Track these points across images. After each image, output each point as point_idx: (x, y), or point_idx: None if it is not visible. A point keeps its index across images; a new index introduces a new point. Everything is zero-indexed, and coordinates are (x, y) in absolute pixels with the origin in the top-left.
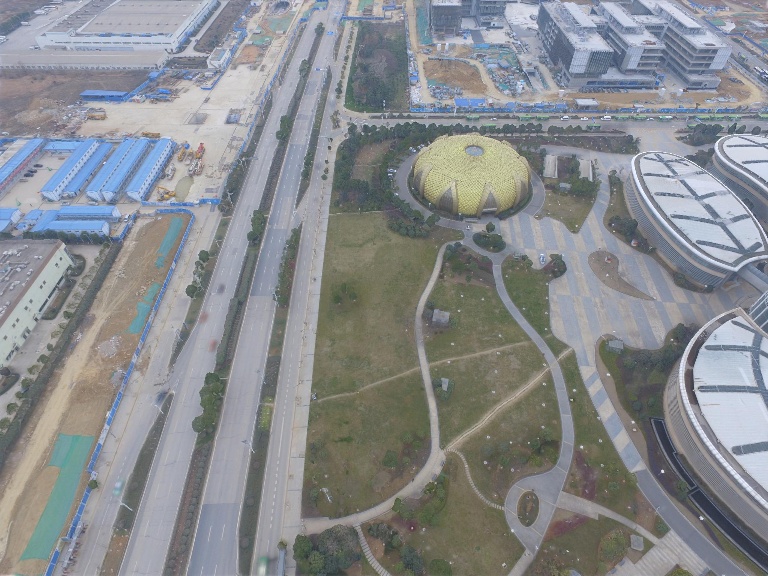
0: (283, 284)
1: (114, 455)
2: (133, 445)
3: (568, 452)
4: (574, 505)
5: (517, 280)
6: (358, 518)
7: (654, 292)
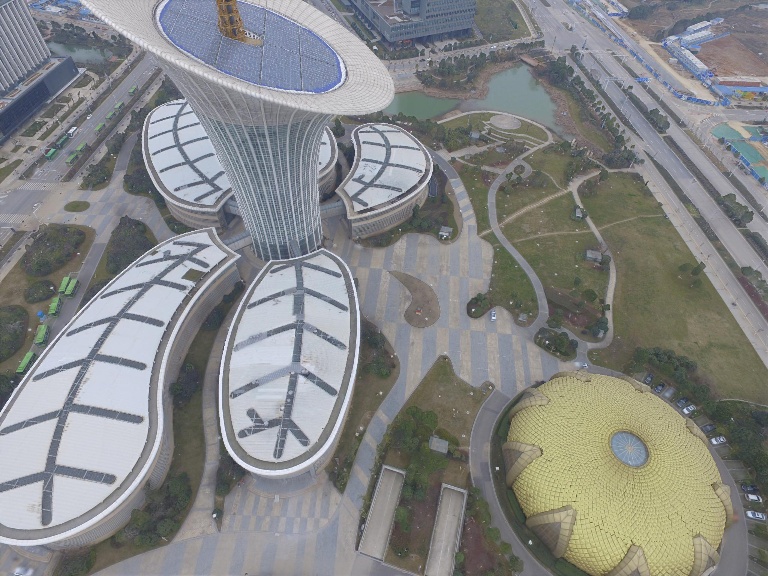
0: (760, 284)
1: (767, 197)
2: (761, 200)
3: (494, 187)
4: (495, 170)
5: (523, 292)
6: (608, 171)
7: (385, 278)
